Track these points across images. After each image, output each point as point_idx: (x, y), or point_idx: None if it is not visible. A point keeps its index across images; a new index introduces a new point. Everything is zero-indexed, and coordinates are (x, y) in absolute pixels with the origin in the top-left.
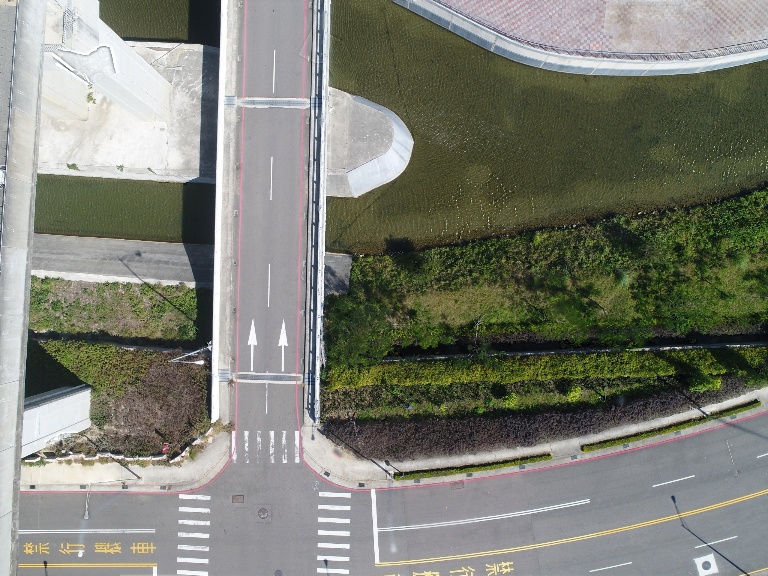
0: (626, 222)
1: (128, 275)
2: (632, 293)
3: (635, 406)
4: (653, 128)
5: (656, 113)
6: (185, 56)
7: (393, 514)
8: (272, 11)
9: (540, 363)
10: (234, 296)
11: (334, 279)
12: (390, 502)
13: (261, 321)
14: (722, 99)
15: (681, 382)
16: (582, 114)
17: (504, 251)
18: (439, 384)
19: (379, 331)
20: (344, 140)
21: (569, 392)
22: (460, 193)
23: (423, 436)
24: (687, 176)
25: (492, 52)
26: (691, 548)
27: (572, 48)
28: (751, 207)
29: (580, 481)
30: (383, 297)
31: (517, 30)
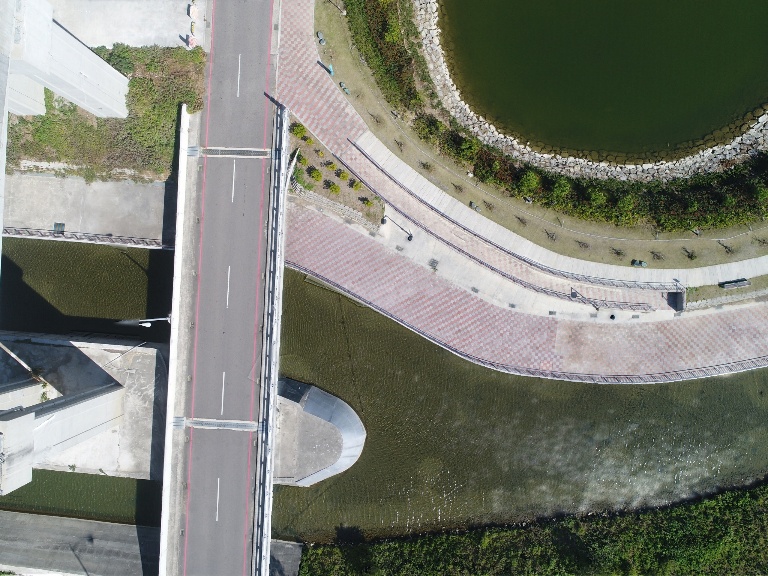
0: (575, 526)
1: (78, 571)
2: None
3: None
4: (606, 428)
5: (609, 413)
6: (138, 359)
7: None
8: (222, 333)
9: None
10: None
11: None
12: None
13: None
14: (676, 402)
15: None
16: (535, 411)
17: (452, 553)
18: None
19: None
20: (293, 449)
21: None
22: (411, 485)
23: None
24: (639, 477)
25: None
26: None
27: (522, 367)
28: (700, 518)
29: None
30: None
31: (468, 347)
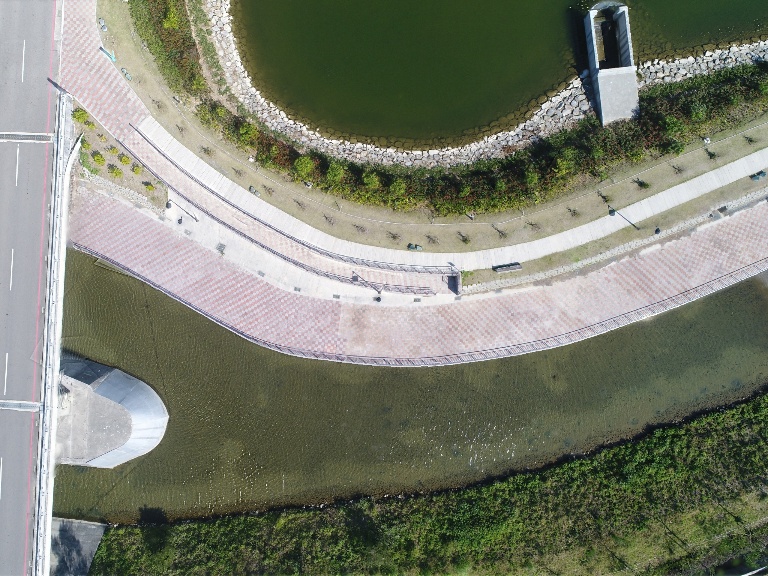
0: (369, 507)
1: None
2: None
3: None
4: (402, 411)
5: (406, 396)
6: None
7: None
8: (6, 315)
9: None
10: None
11: (77, 559)
12: None
13: None
14: (471, 385)
15: None
16: (334, 394)
17: (247, 534)
18: None
19: None
20: (84, 430)
21: None
22: (213, 467)
23: None
24: (435, 460)
25: None
26: None
27: (307, 349)
28: (490, 500)
29: None
30: None
31: (254, 329)
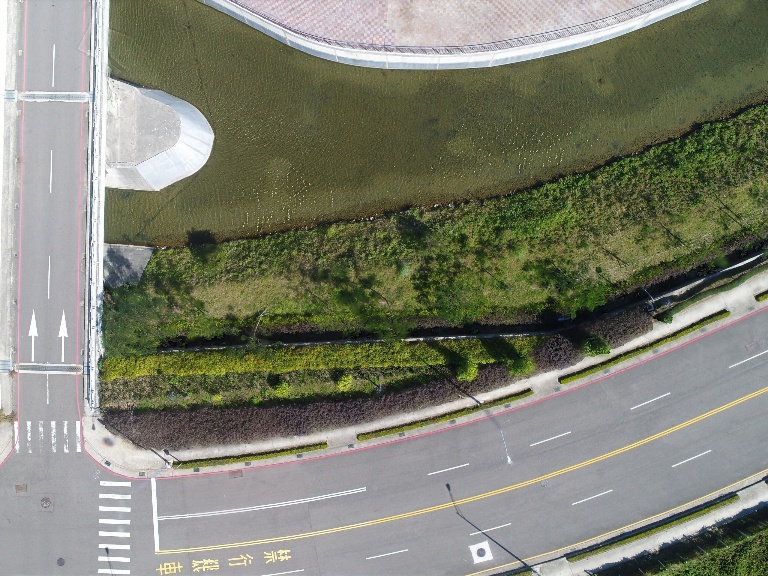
0: (420, 214)
1: None
2: (414, 284)
3: (404, 395)
4: (450, 121)
5: (453, 106)
6: None
7: (173, 503)
8: (52, 6)
9: (313, 353)
10: (15, 288)
11: (128, 271)
12: (170, 491)
13: (41, 312)
14: (517, 92)
15: (452, 371)
16: (380, 108)
17: (298, 243)
18: (214, 374)
19: (167, 322)
20: (132, 134)
21: (338, 381)
22: (261, 186)
23: (196, 425)
24: (483, 169)
25: (290, 46)
26: (466, 535)
27: (355, 42)
28: (541, 199)
29: (356, 469)
30: (171, 289)
31: (301, 24)
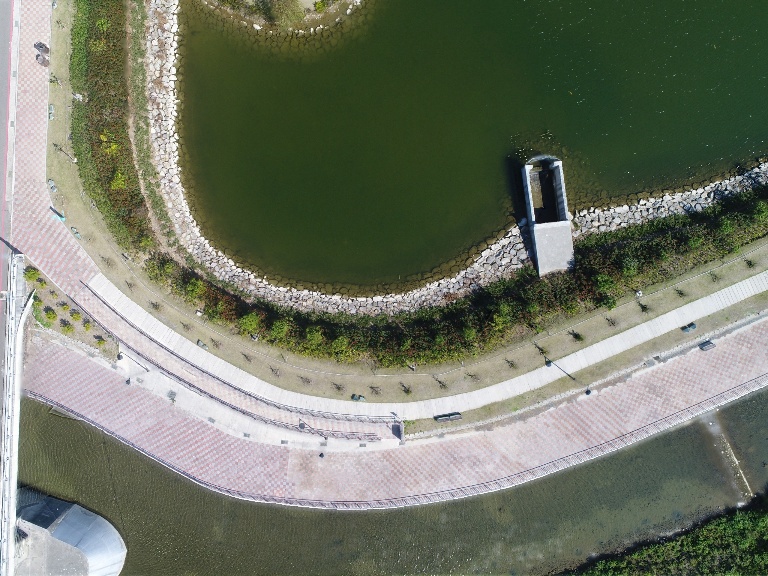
0: None
1: None
2: None
3: None
4: (353, 544)
5: (357, 529)
6: None
7: None
8: None
9: None
10: None
11: None
12: None
13: None
14: (420, 518)
15: None
16: (287, 527)
17: None
18: None
19: None
20: (42, 573)
21: None
22: None
23: None
24: None
25: None
26: None
27: (257, 493)
28: None
29: None
30: None
31: (205, 474)
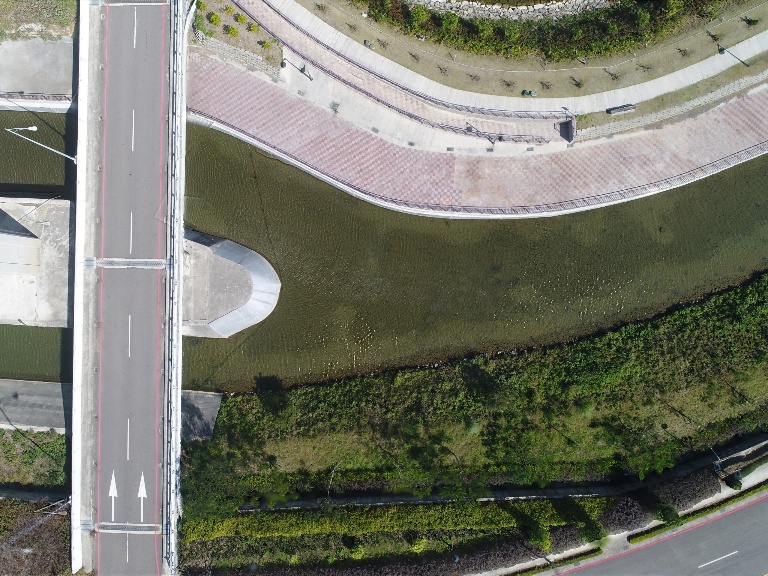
0: (484, 363)
1: (1, 421)
2: (482, 440)
3: (477, 558)
4: (512, 269)
5: (515, 255)
6: (53, 211)
7: None
8: (129, 175)
9: (387, 515)
10: (95, 450)
11: (200, 423)
12: None
13: (121, 474)
14: (579, 241)
15: (523, 533)
16: (443, 256)
17: (365, 393)
18: (291, 535)
19: (240, 476)
20: (205, 292)
21: (413, 545)
22: (327, 333)
23: None
24: (545, 316)
25: (355, 197)
26: None
27: (423, 202)
28: (604, 349)
29: None
30: (244, 443)
31: (370, 185)
